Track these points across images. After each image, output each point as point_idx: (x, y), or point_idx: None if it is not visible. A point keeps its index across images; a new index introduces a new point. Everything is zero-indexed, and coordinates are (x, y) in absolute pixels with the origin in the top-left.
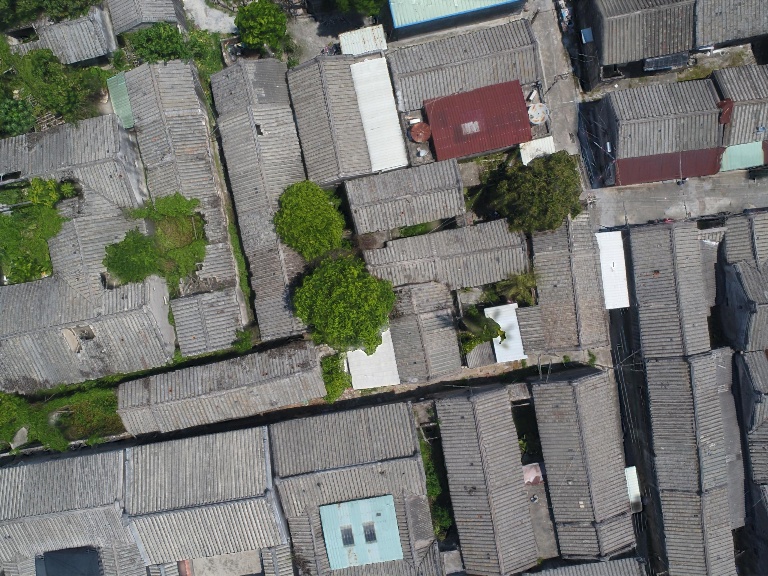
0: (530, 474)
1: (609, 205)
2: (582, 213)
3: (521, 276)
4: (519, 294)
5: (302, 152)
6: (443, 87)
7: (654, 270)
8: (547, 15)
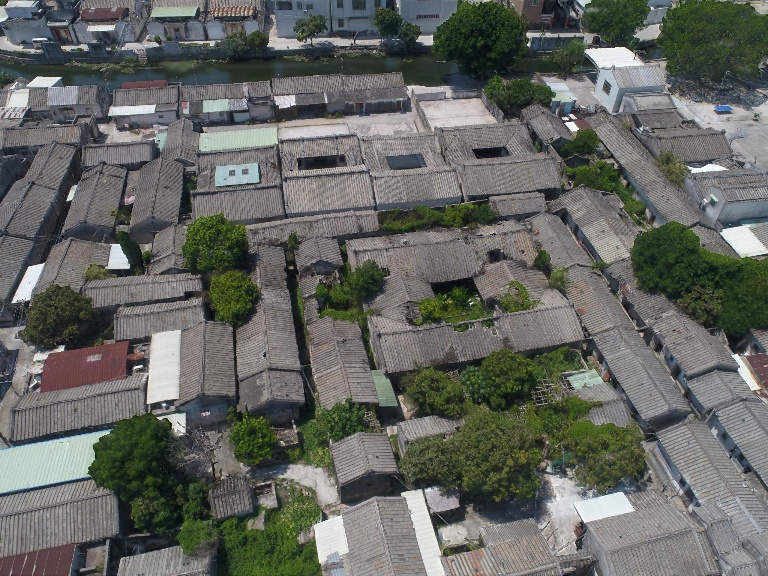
0: (132, 199)
1: (12, 340)
2: None
3: (95, 274)
4: None
5: (235, 346)
6: None
7: (0, 277)
8: None
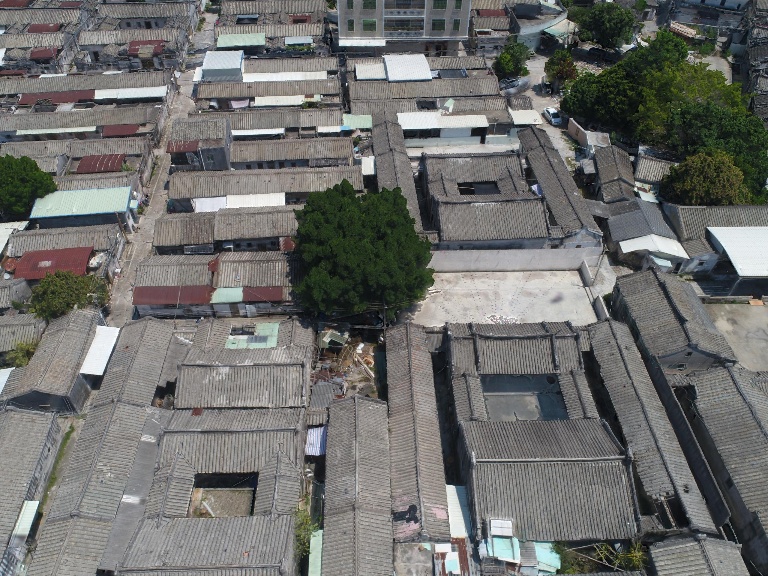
0: None
1: None
2: (91, 310)
3: None
4: (18, 358)
5: None
6: (42, 245)
7: None
8: (149, 236)
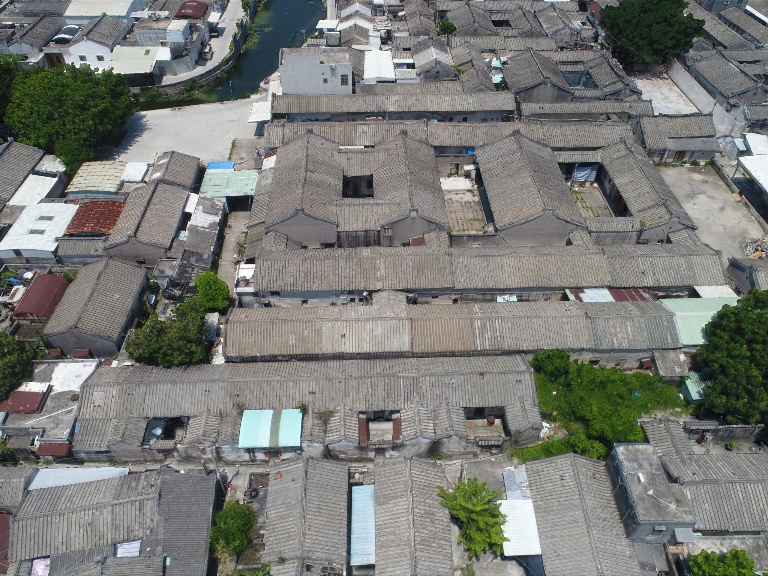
0: None
1: None
2: None
3: None
4: None
5: None
6: None
7: None
8: None
